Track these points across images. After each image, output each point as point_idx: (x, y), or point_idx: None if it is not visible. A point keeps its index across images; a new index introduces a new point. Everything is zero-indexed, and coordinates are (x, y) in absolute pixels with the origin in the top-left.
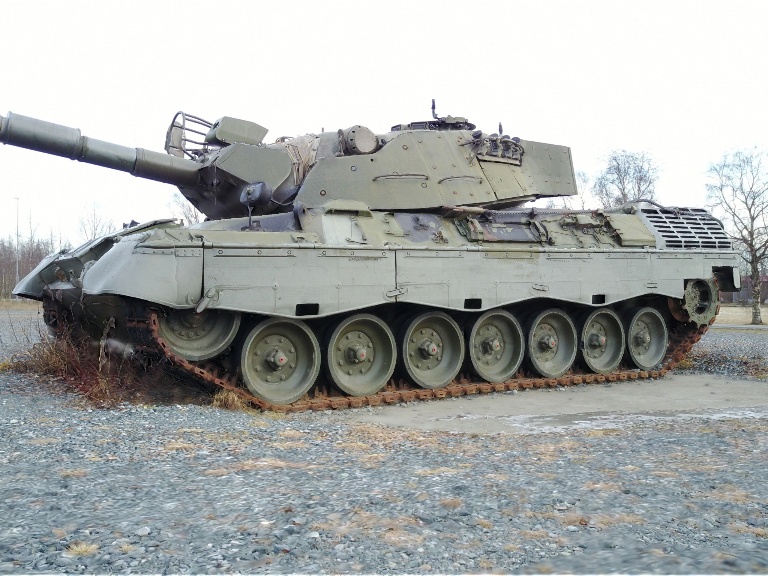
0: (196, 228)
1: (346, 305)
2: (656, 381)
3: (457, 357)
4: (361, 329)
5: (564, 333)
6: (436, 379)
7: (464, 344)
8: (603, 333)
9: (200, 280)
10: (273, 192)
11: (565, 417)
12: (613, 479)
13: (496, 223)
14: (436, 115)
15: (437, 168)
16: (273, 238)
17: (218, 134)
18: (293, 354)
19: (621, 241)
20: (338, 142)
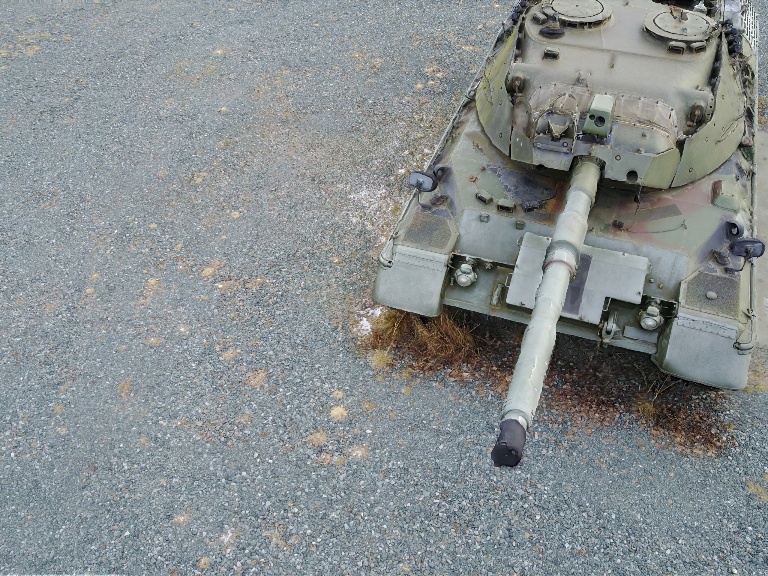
0: (666, 263)
1: None
2: None
3: None
4: None
5: None
6: None
7: None
8: None
9: None
10: None
11: None
12: None
13: None
14: None
15: None
16: None
17: None
18: None
19: None
20: (689, 112)
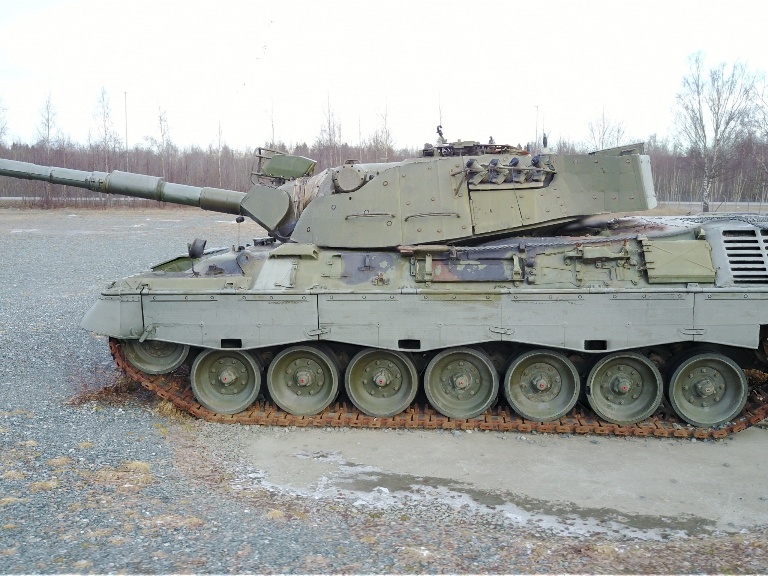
0: None
1: (267, 341)
2: (692, 444)
3: (410, 390)
4: (309, 357)
5: (567, 375)
6: (386, 408)
7: (418, 378)
8: (638, 377)
9: (141, 318)
10: (274, 228)
11: (393, 479)
12: (13, 570)
13: (468, 259)
14: (446, 140)
15: (411, 204)
16: (208, 284)
17: (267, 170)
18: (245, 373)
19: (648, 277)
20: None
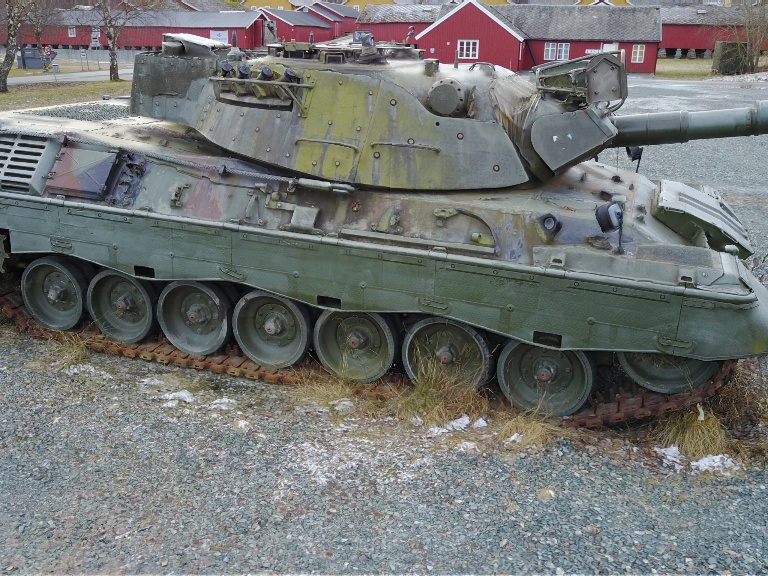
0: None
1: None
2: None
3: None
4: None
5: None
6: None
7: None
8: None
9: None
10: None
11: None
12: None
13: None
14: None
15: None
16: None
17: None
18: None
19: None
20: None
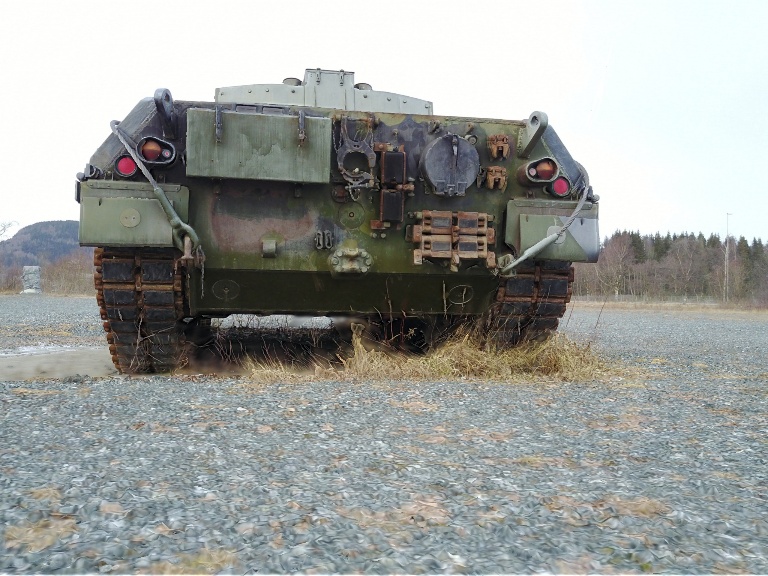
0: None
1: None
2: (112, 371)
3: None
4: None
5: None
6: None
7: None
8: None
9: None
10: None
11: None
12: None
13: None
14: None
15: None
16: None
17: None
18: None
19: None
20: None
